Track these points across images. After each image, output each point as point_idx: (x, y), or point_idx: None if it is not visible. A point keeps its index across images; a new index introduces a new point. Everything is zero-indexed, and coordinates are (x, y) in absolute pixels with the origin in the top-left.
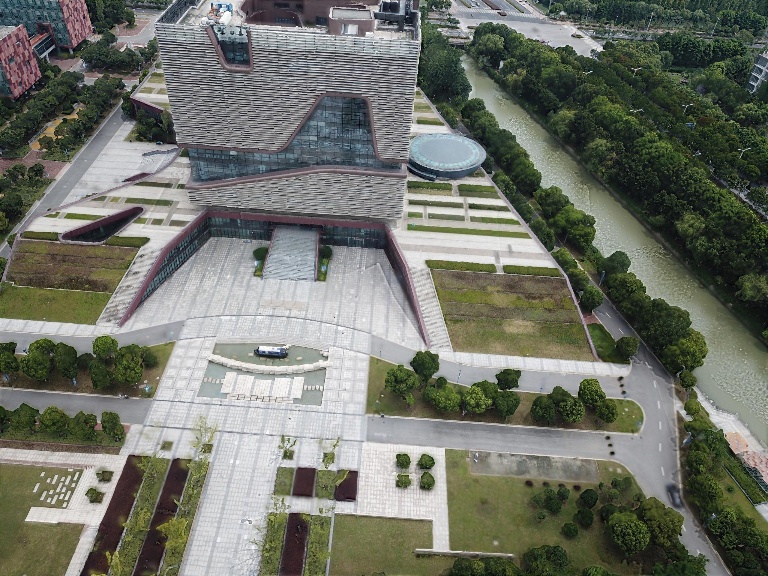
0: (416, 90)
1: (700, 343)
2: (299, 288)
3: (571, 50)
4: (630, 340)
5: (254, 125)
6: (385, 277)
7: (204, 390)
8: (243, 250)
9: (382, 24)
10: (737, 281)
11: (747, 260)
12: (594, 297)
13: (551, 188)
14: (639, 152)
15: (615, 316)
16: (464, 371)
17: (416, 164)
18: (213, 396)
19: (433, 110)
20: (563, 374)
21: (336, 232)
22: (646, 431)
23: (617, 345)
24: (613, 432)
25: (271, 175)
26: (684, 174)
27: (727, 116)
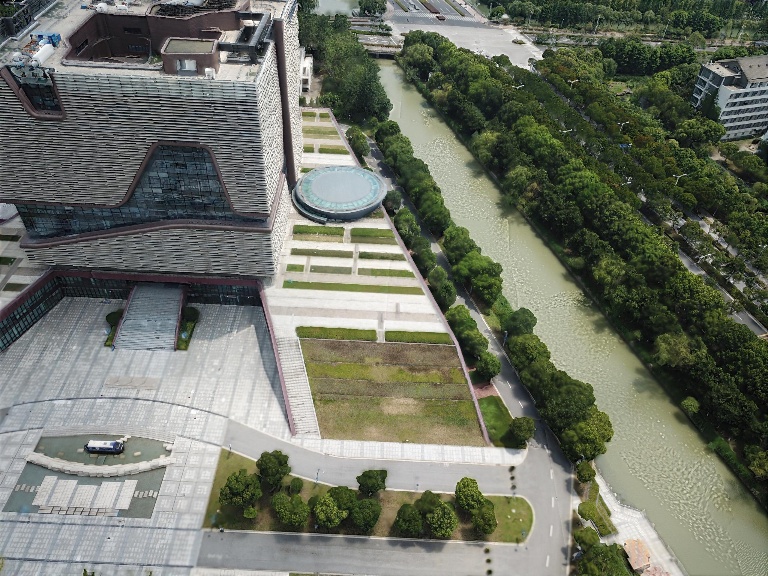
0: (325, 112)
1: (602, 427)
2: (154, 360)
3: (505, 60)
4: (522, 423)
5: (83, 178)
6: (258, 343)
7: (13, 502)
8: (98, 313)
9: (231, 56)
10: (656, 341)
11: (668, 315)
12: (489, 367)
13: (457, 229)
14: (563, 181)
15: (516, 385)
16: (330, 464)
17: (305, 205)
18: (22, 510)
19: (340, 136)
20: (446, 464)
21: (205, 290)
22: (533, 539)
23: (510, 427)
24: (494, 542)
25: (116, 231)
26: (607, 209)
27: (669, 132)
